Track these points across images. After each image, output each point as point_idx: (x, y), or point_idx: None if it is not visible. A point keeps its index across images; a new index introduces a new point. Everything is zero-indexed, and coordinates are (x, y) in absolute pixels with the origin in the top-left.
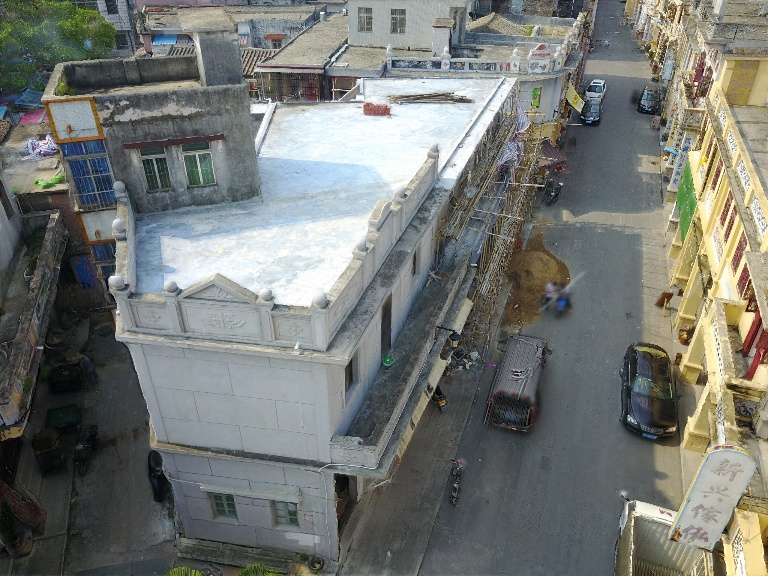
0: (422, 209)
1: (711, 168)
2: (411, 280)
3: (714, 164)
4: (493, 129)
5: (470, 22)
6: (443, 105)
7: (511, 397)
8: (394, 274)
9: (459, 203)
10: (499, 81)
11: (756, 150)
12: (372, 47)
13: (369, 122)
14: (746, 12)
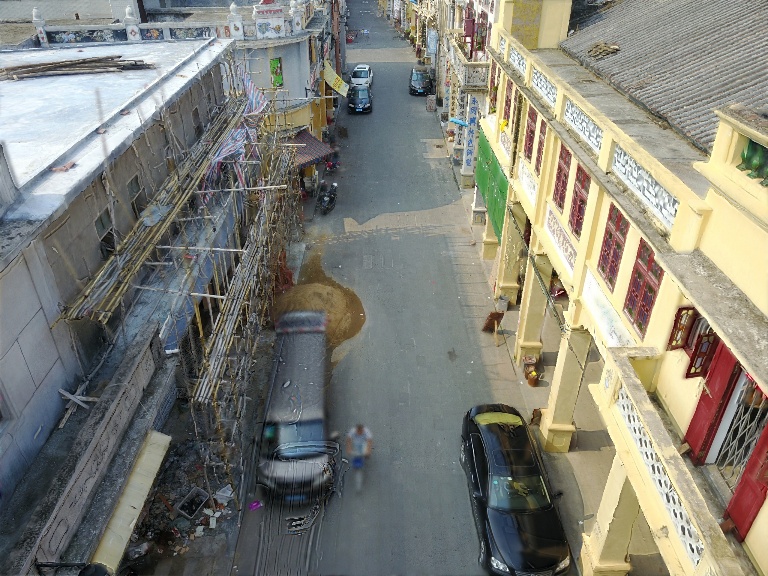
0: None
1: (519, 130)
2: None
3: (522, 124)
4: None
5: None
6: (98, 75)
7: (294, 569)
8: None
9: (127, 239)
10: (205, 42)
11: None
12: (25, 22)
13: None
14: None
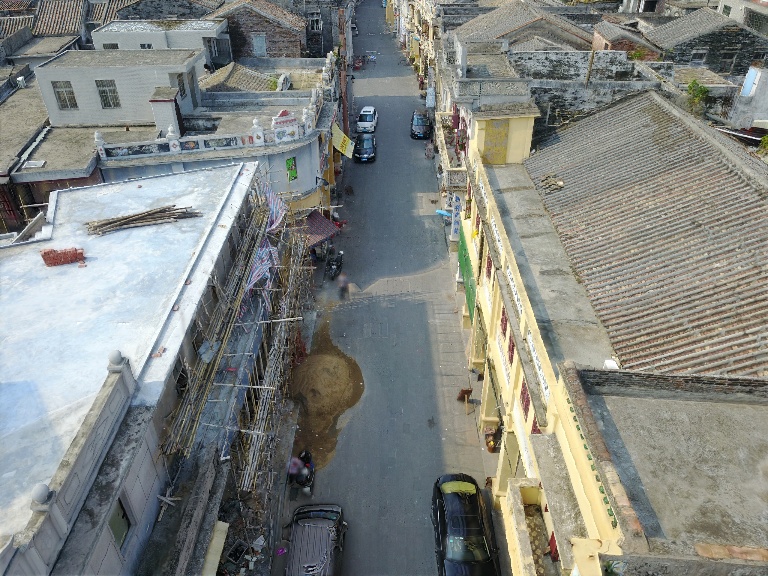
0: (107, 464)
1: (482, 252)
2: (118, 554)
3: (484, 248)
4: (241, 228)
5: (208, 75)
6: (161, 227)
7: None
8: None
9: (192, 376)
10: (236, 171)
11: (522, 234)
12: (83, 127)
13: (51, 280)
14: (488, 50)
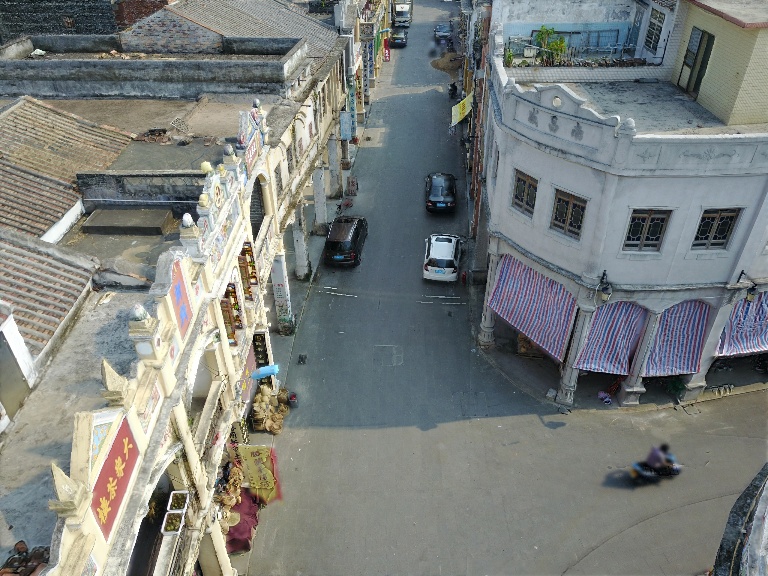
0: None
1: None
2: None
3: None
4: None
5: None
6: None
7: None
8: None
9: None
10: None
11: None
12: None
13: None
14: None
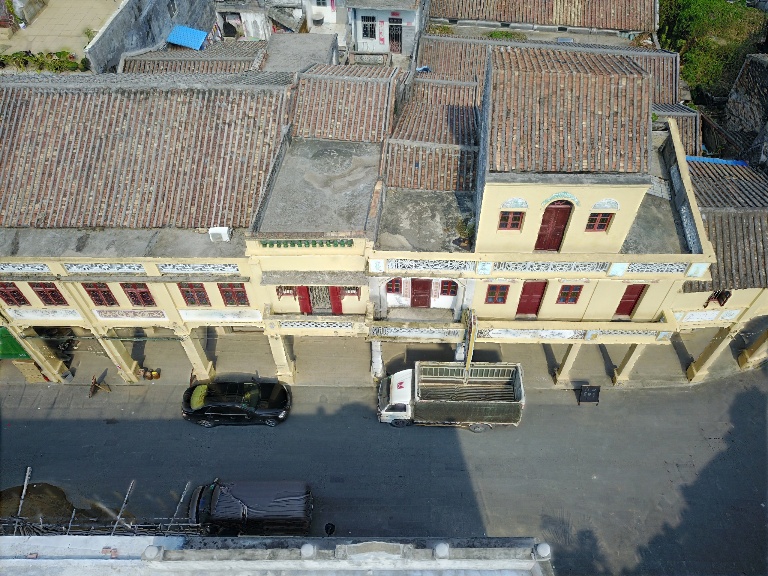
0: None
1: None
2: None
3: None
4: None
5: None
6: None
7: (264, 519)
8: (399, 542)
9: None
10: None
11: (8, 253)
12: None
13: None
14: None
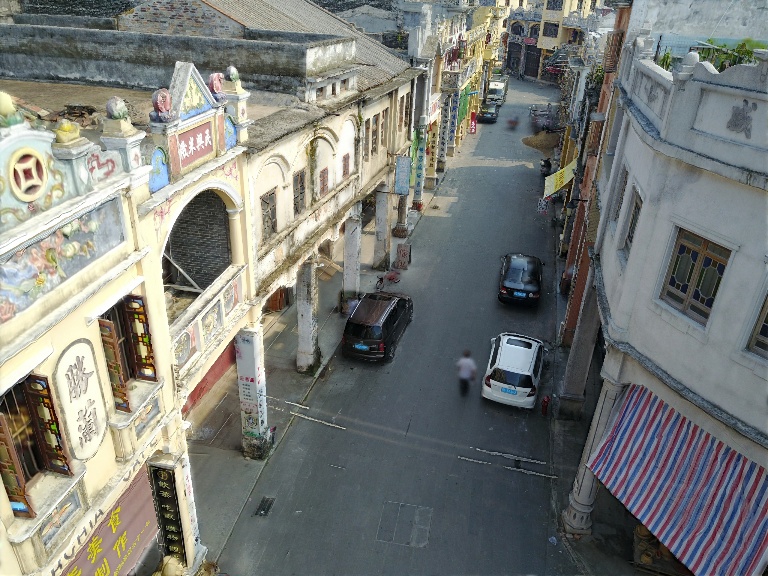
0: None
1: None
2: None
3: None
4: None
5: None
6: None
7: None
8: None
9: None
10: None
11: None
12: None
13: None
14: None
